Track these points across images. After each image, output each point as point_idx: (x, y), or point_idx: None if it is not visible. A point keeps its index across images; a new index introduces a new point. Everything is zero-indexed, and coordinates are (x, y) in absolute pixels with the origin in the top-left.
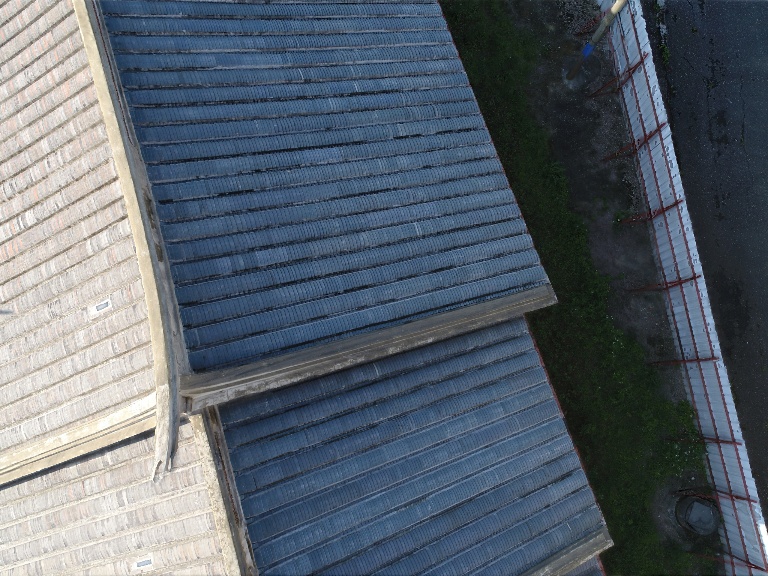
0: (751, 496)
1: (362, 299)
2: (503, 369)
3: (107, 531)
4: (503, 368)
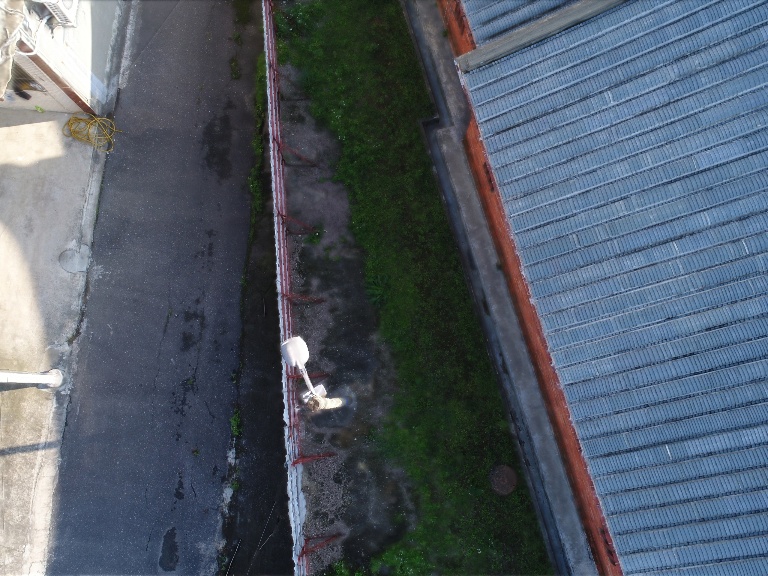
0: None
1: (679, 8)
2: (511, 3)
3: None
4: (511, 4)
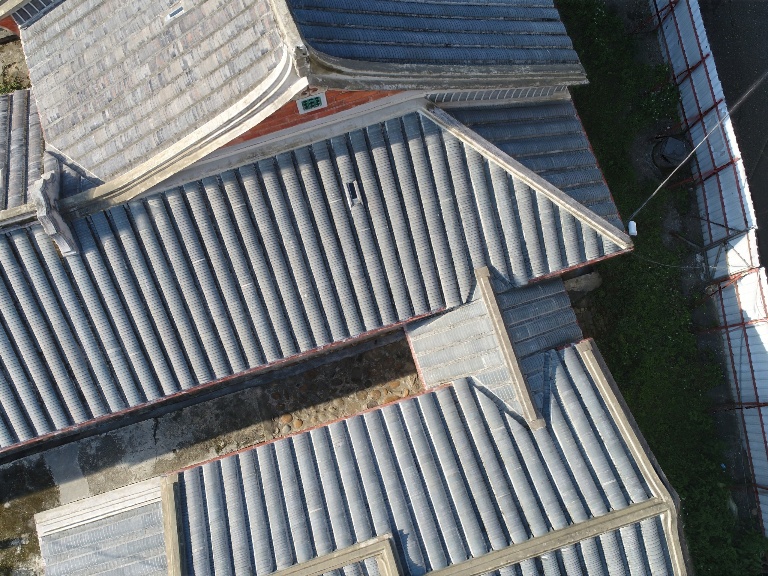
0: (718, 100)
1: None
2: None
3: (143, 4)
4: None
